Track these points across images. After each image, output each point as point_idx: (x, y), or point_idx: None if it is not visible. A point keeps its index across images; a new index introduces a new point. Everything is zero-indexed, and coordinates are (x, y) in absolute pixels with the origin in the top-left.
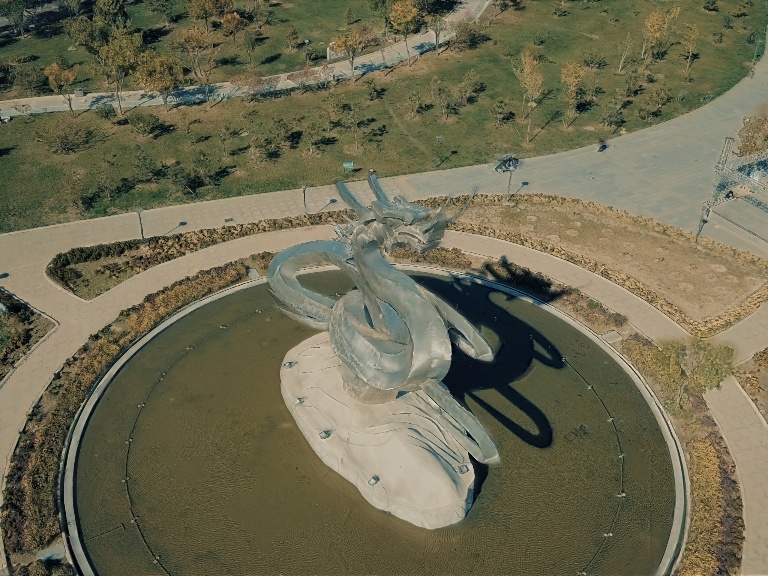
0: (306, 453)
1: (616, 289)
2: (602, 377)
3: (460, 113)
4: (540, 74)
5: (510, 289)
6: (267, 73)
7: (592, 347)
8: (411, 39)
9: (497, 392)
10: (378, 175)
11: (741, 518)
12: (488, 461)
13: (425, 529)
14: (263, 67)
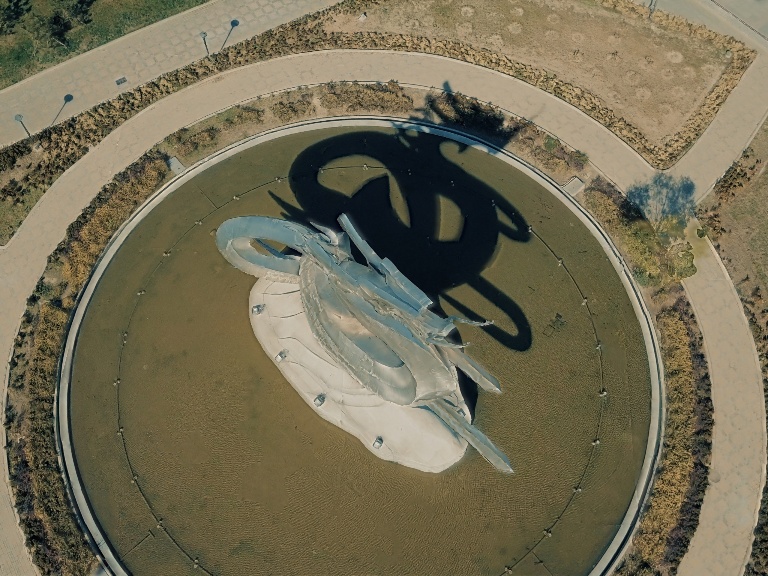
0: (297, 397)
1: (572, 113)
2: (570, 245)
3: None
4: None
5: (461, 136)
6: None
7: (556, 205)
8: None
9: (470, 288)
10: None
11: (710, 399)
12: None
13: (432, 473)
14: None
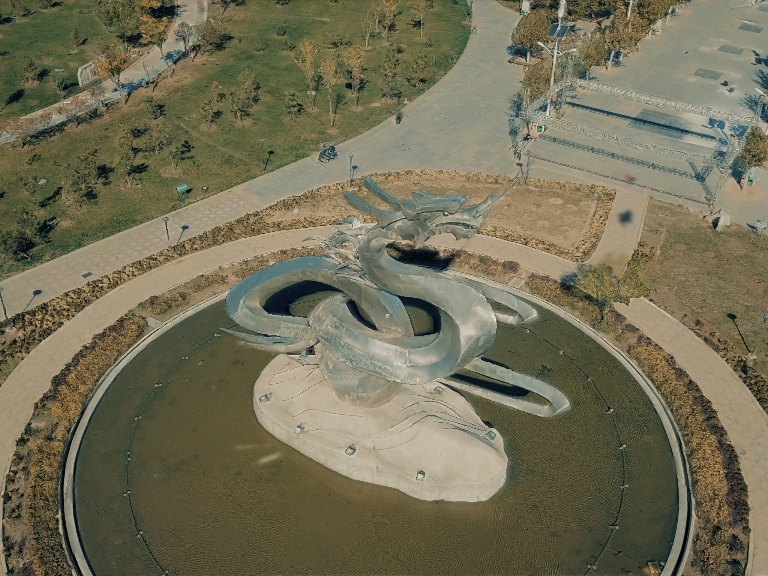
0: (320, 478)
1: (492, 241)
2: None
3: (251, 114)
4: (333, 61)
5: None
6: (22, 112)
7: None
8: (154, 50)
9: None
10: (213, 191)
11: (703, 396)
12: (557, 413)
13: (481, 502)
14: (12, 107)
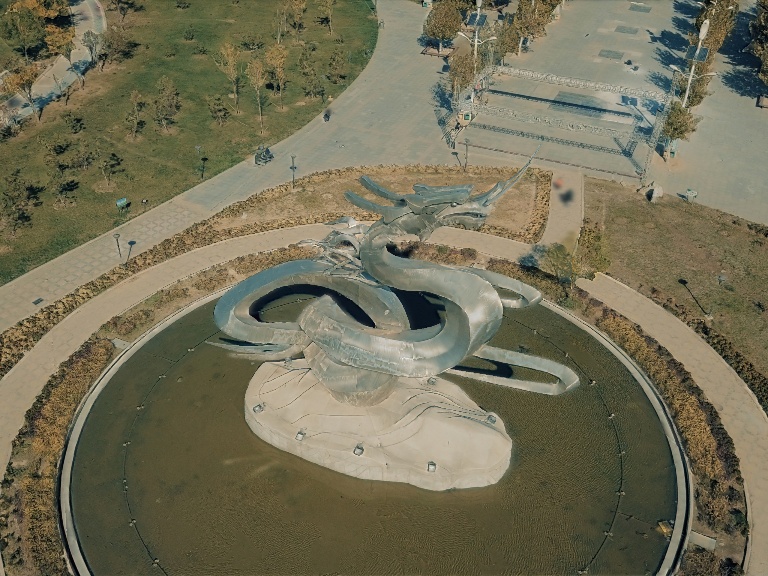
0: (326, 482)
1: (446, 230)
2: None
3: (176, 121)
4: (259, 62)
5: None
6: None
7: None
8: (57, 62)
9: None
10: (153, 204)
11: (674, 359)
12: (567, 390)
13: (491, 486)
14: None
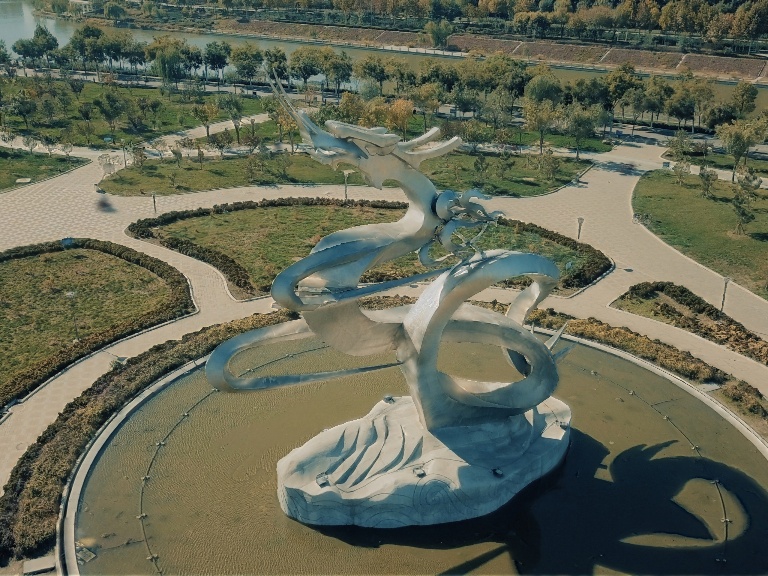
0: None
1: None
2: None
3: None
4: None
5: None
6: None
7: None
8: None
9: None
10: None
11: None
12: None
13: None
14: None
